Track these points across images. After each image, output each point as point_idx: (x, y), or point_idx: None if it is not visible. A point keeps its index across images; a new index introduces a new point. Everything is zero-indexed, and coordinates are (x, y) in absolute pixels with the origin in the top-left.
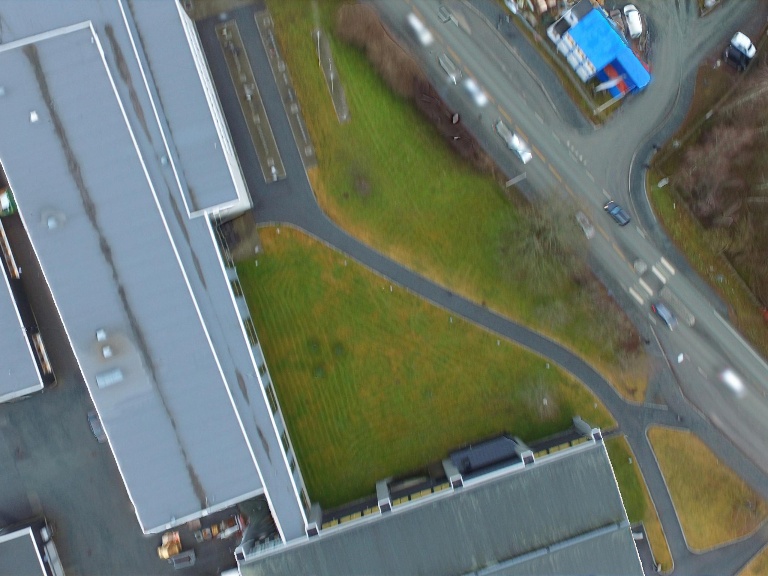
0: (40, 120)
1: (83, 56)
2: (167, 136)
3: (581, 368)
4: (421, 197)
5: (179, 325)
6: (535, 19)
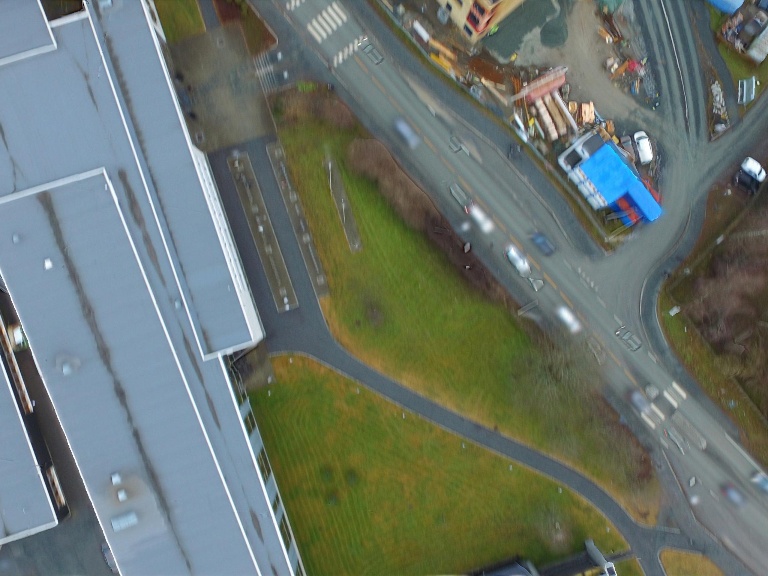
0: (54, 267)
1: (97, 202)
2: (181, 279)
3: (593, 491)
4: (433, 324)
5: (194, 467)
6: (546, 147)
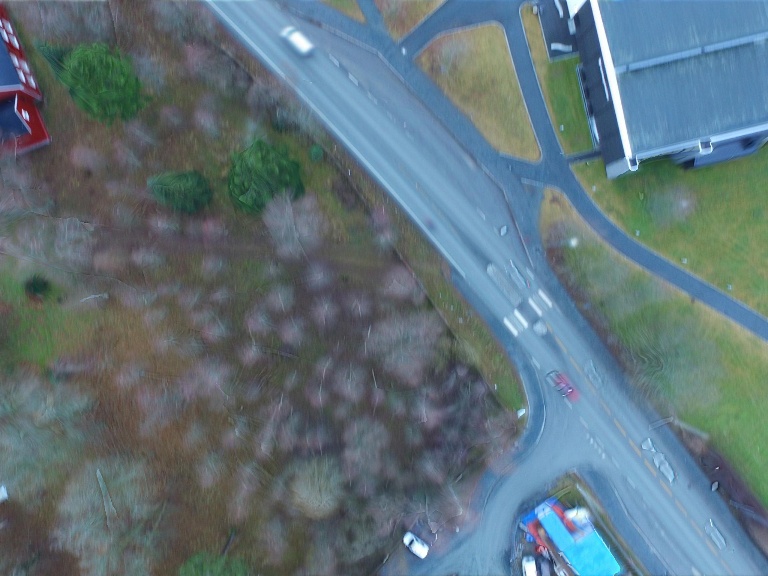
0: None
1: None
2: None
3: (603, 228)
4: (749, 411)
5: None
6: None
